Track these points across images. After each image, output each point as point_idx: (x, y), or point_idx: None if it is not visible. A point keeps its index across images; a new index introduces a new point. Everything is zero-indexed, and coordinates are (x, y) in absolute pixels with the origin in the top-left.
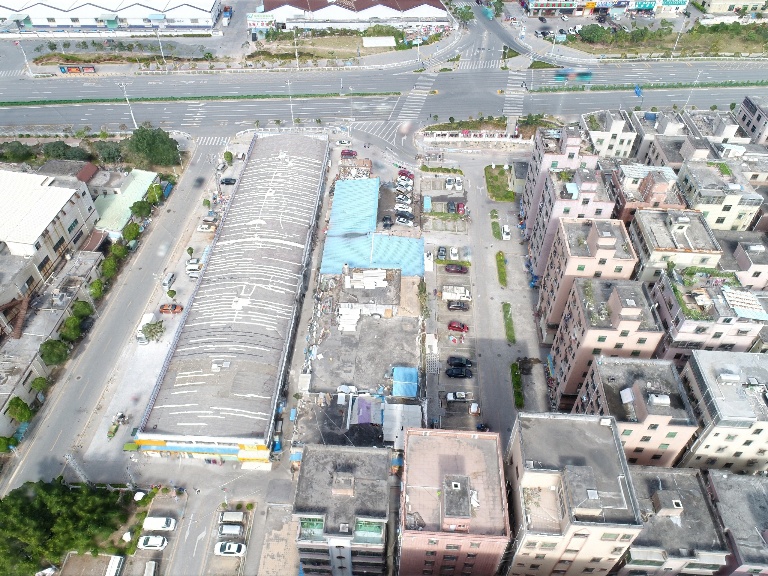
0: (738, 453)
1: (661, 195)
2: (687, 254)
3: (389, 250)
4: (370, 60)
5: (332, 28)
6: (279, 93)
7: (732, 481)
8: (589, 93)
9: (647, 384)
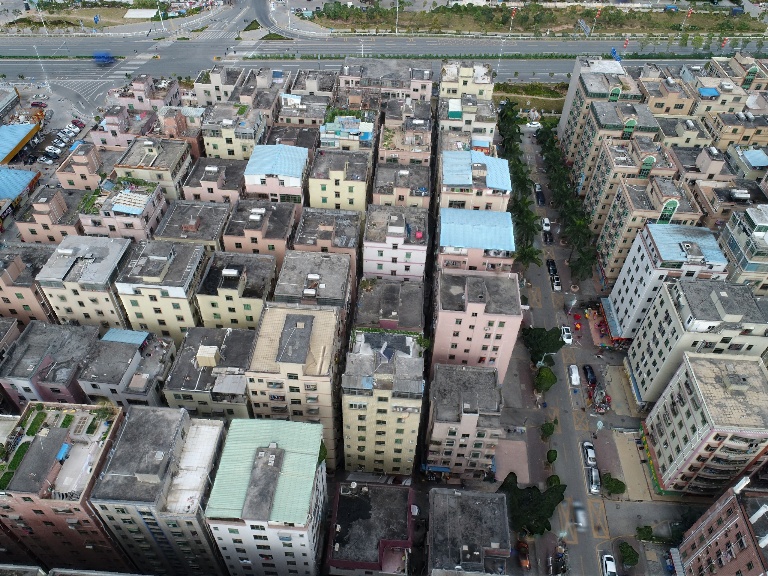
0: (86, 315)
1: (170, 128)
2: (141, 170)
3: (0, 180)
4: (121, 29)
5: (103, 0)
6: (15, 54)
7: (49, 329)
8: (298, 61)
9: (5, 256)
